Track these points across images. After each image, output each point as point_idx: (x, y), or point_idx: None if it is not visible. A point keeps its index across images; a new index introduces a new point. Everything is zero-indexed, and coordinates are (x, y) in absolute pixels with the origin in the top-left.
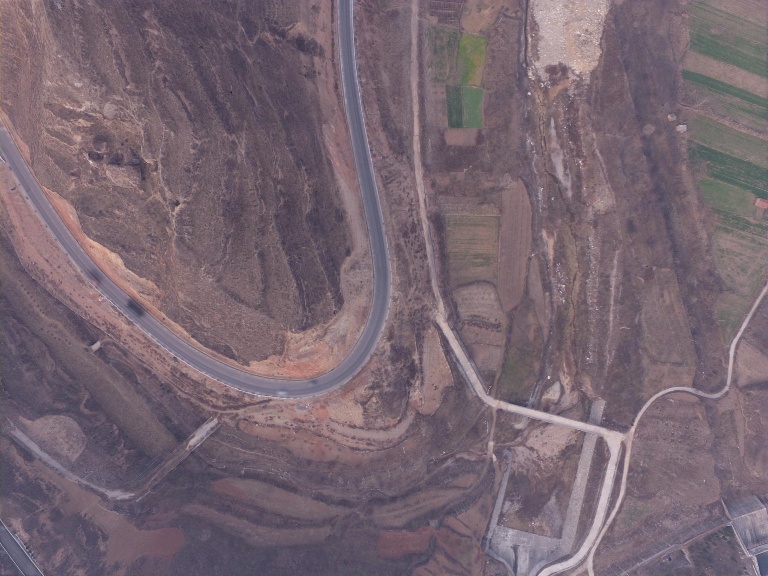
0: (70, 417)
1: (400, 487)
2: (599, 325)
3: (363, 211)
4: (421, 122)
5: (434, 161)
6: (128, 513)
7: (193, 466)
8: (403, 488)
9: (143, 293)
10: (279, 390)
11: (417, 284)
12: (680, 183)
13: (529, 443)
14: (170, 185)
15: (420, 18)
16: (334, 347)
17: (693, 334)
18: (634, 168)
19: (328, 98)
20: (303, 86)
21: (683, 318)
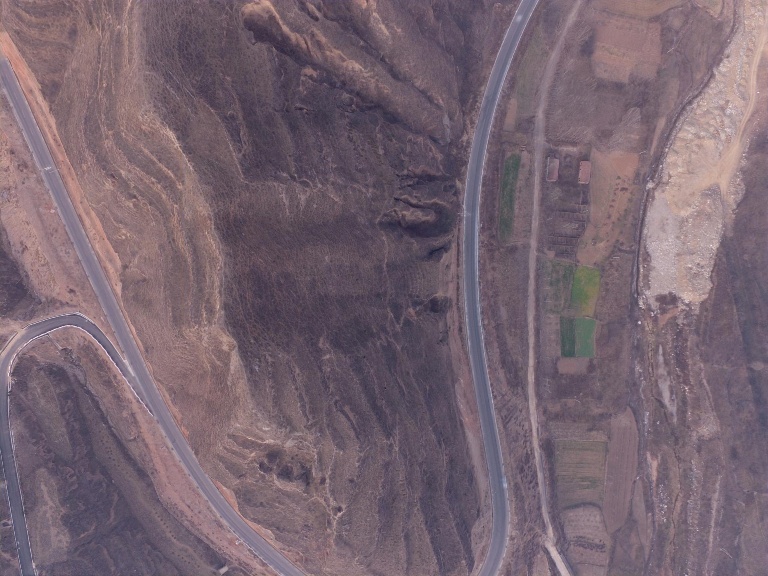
0: None
1: None
2: (699, 545)
3: (484, 452)
4: (536, 354)
5: None
6: None
7: None
8: None
9: (284, 550)
10: None
11: (531, 516)
12: None
13: None
14: (335, 494)
15: (538, 253)
16: None
17: None
18: (739, 397)
19: (455, 348)
20: (441, 355)
21: None
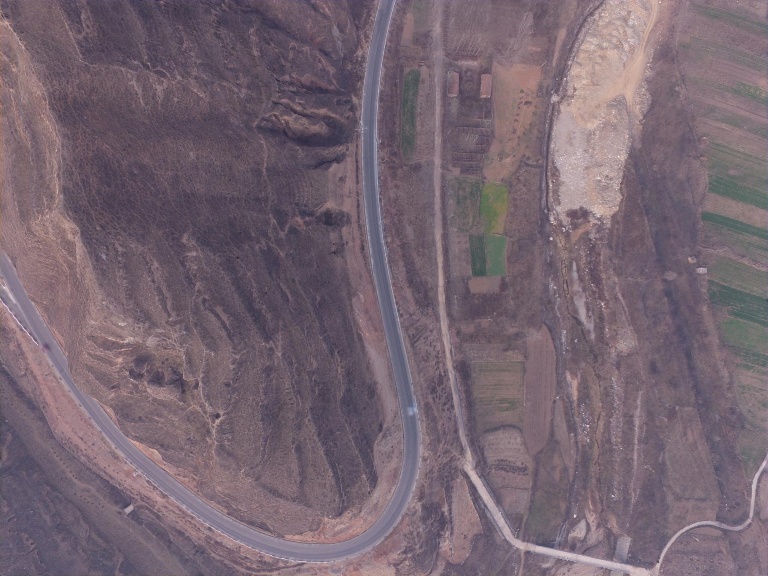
0: None
1: None
2: (623, 464)
3: (392, 372)
4: (446, 273)
5: (459, 310)
6: None
7: None
8: None
9: (179, 475)
10: (313, 554)
11: (445, 438)
12: (701, 323)
13: None
14: (210, 400)
15: (443, 170)
16: (368, 518)
17: (716, 470)
18: (656, 310)
19: (356, 264)
20: (333, 266)
21: (706, 455)
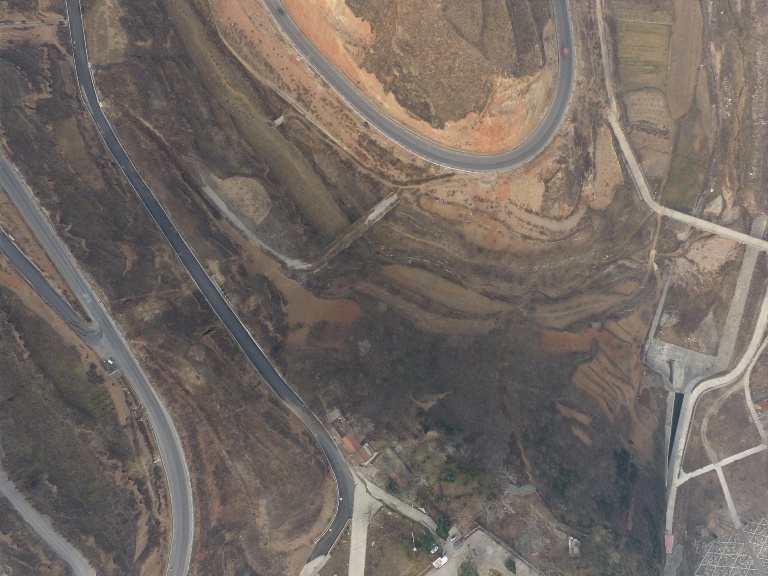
0: (257, 180)
1: (562, 289)
2: (764, 140)
3: None
4: None
5: None
6: (305, 283)
7: (363, 251)
8: (565, 290)
9: (350, 43)
10: (464, 163)
11: (596, 76)
12: None
13: (690, 255)
14: None
15: None
16: (529, 113)
17: None
18: None
19: None
20: None
21: None
